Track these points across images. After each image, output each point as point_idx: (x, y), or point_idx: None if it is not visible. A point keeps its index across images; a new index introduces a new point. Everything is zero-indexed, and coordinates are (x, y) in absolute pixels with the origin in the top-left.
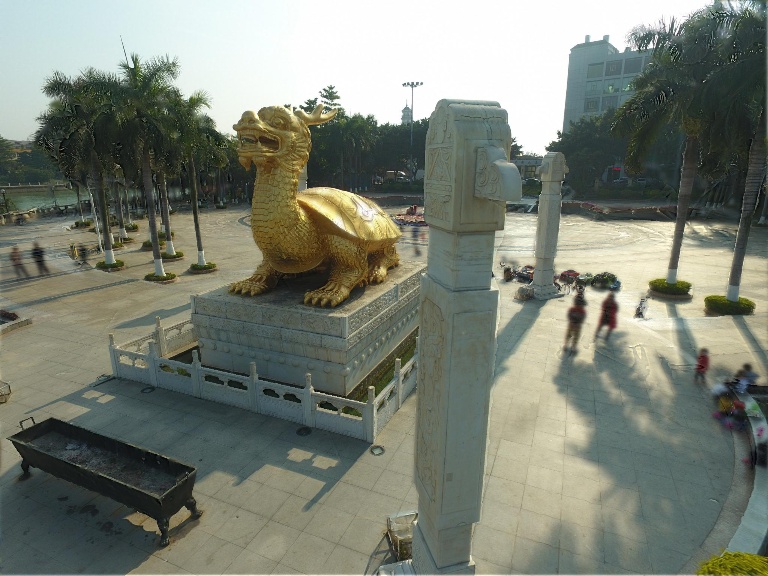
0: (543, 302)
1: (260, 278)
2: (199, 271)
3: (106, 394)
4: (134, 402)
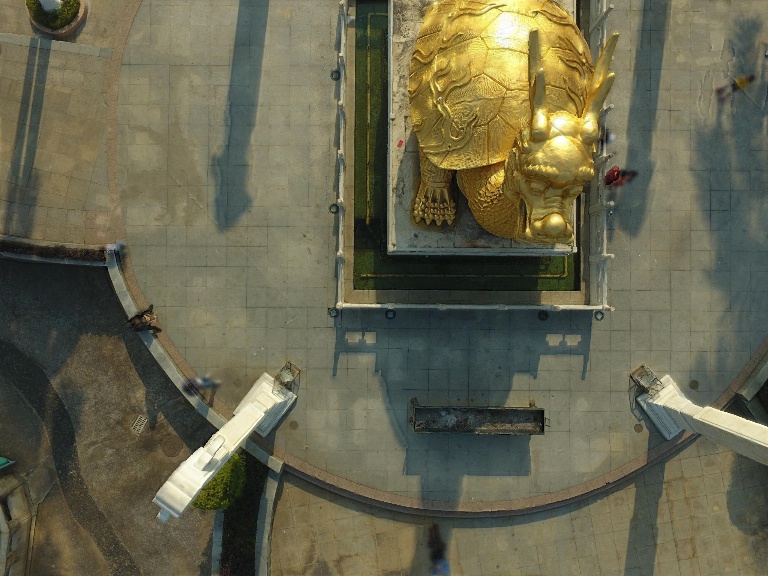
0: None
1: (441, 194)
2: None
3: (364, 333)
4: (397, 333)
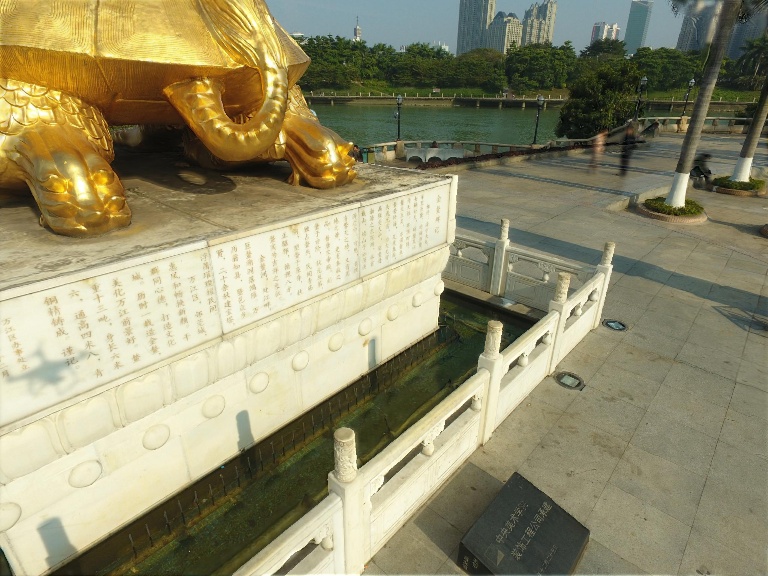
0: None
1: None
2: (767, 230)
3: None
4: None
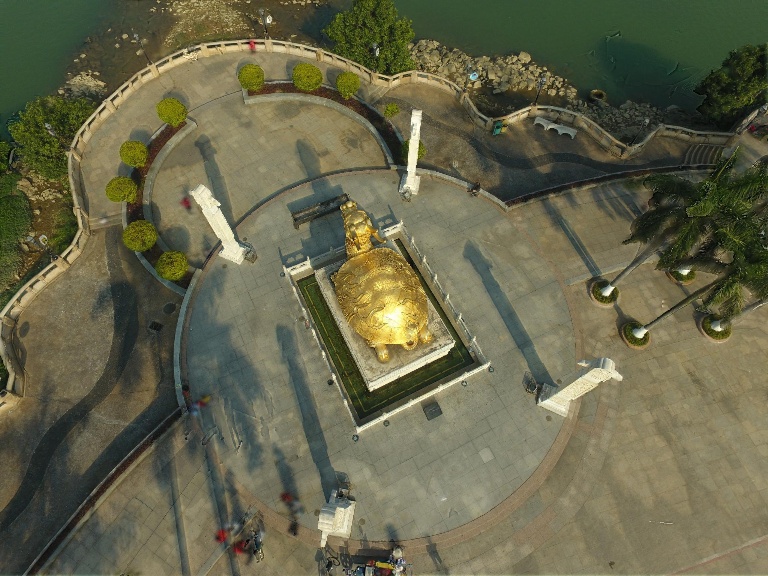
0: (327, 493)
1: None
2: (623, 327)
3: (385, 224)
4: None
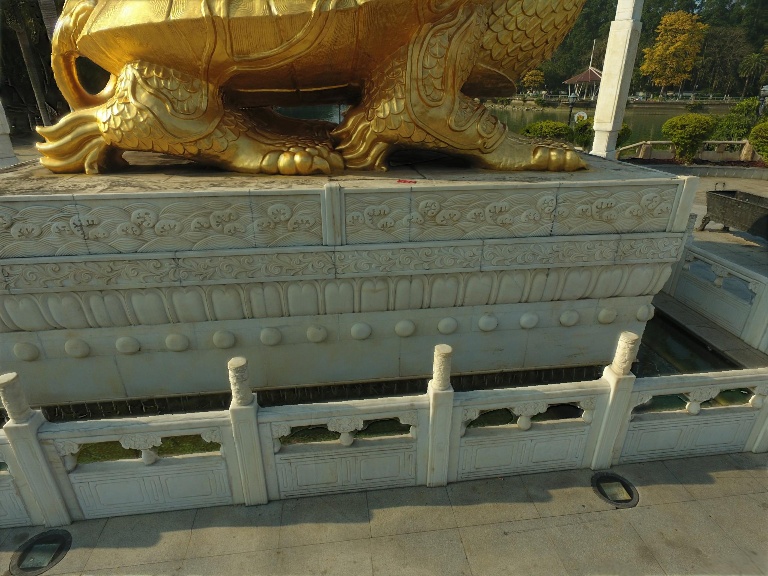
0: None
1: None
2: None
3: None
4: None
